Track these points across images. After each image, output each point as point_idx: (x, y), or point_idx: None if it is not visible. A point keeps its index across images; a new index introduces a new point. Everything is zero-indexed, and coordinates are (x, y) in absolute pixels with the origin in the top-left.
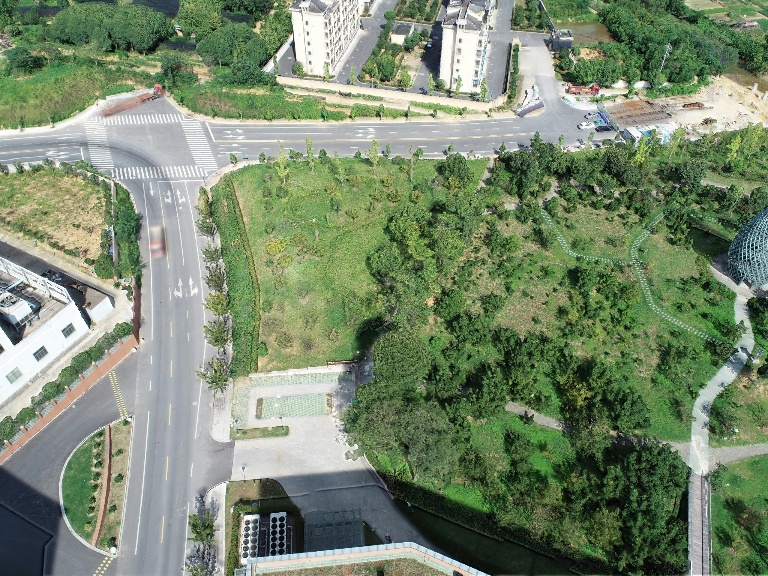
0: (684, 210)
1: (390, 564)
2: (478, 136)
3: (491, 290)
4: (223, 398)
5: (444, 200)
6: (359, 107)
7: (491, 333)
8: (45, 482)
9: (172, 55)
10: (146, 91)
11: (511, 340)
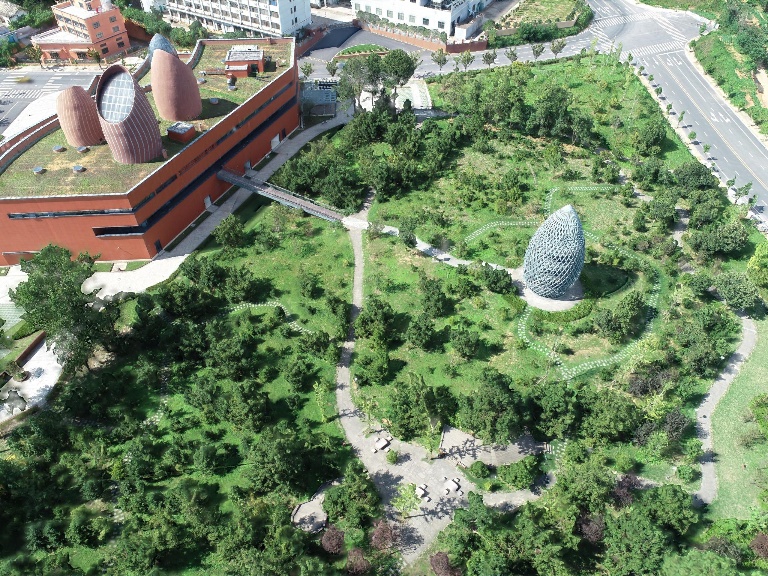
0: (641, 261)
1: (288, 67)
2: (761, 180)
3: (501, 151)
4: (411, 78)
5: (615, 141)
6: (758, 108)
7: (448, 136)
8: (362, 41)
9: (740, 4)
10: (708, 22)
11: (439, 138)
